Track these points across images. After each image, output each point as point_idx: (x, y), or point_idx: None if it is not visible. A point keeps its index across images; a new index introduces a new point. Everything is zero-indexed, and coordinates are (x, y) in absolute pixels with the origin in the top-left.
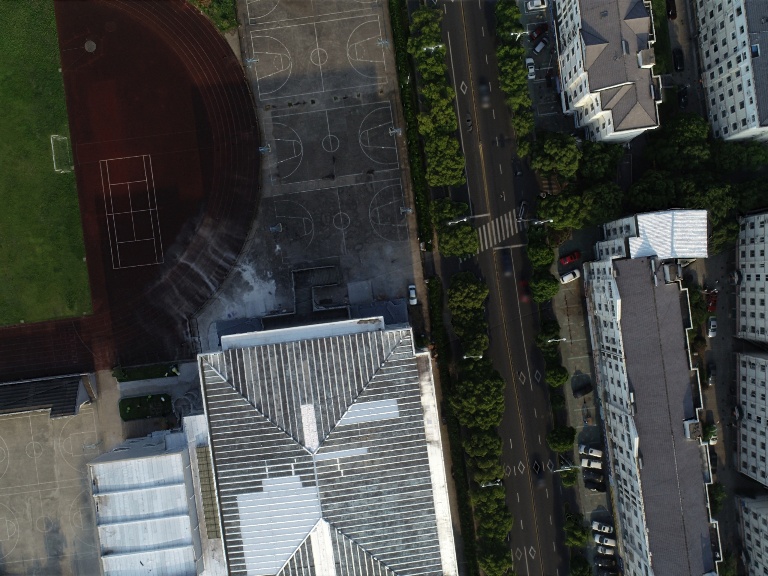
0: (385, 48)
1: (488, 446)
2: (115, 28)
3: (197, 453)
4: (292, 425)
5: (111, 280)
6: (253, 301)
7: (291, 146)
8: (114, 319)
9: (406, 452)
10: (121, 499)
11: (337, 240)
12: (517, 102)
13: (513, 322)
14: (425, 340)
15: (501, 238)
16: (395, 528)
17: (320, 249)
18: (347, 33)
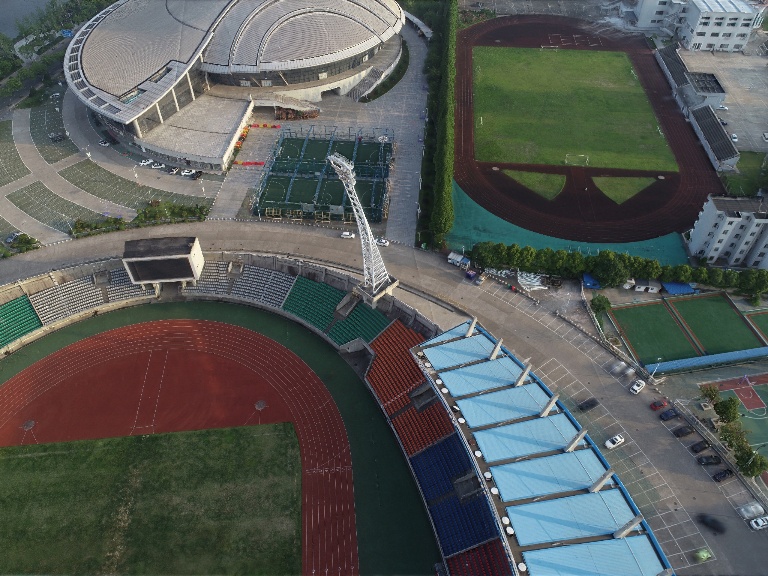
0: None
1: None
2: None
3: None
4: None
5: None
6: (614, 21)
7: (546, 10)
8: None
9: None
10: None
11: None
12: None
13: None
14: None
15: None
16: None
17: None
18: None
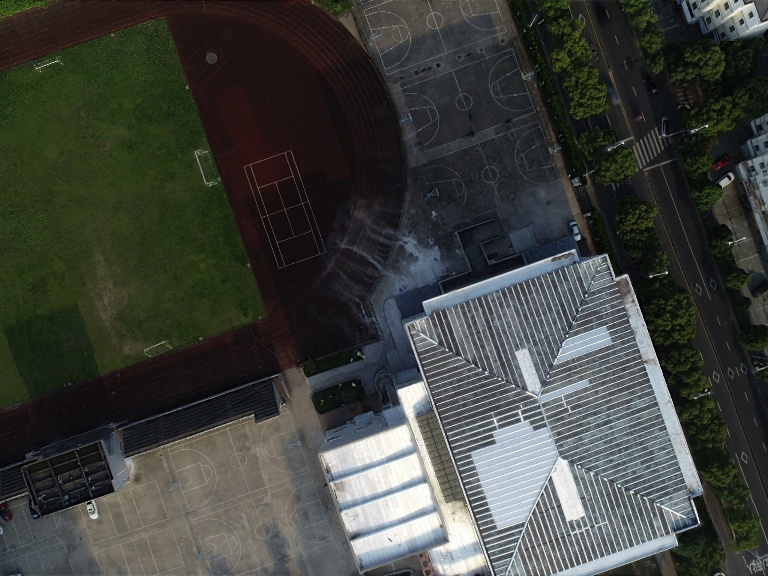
0: None
1: (689, 359)
2: (232, 35)
3: (418, 422)
4: (511, 373)
5: (279, 280)
6: (421, 271)
7: (426, 113)
8: (289, 317)
9: (626, 376)
10: (357, 481)
11: (490, 194)
12: (645, 20)
13: (678, 237)
14: None
15: (649, 158)
16: (631, 452)
17: (475, 206)
18: None
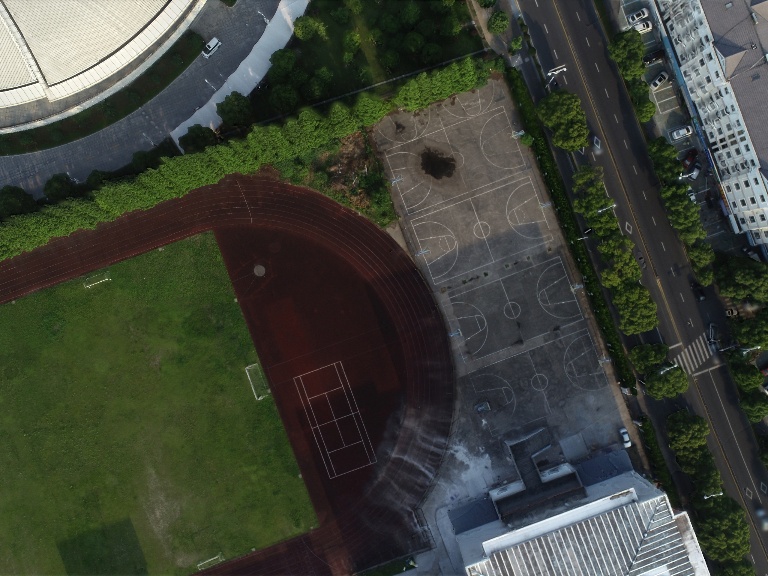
0: (544, 207)
1: (745, 575)
2: (279, 248)
3: None
4: None
5: (330, 490)
6: (472, 479)
7: (474, 321)
8: (341, 527)
9: None
10: None
11: (539, 402)
12: (694, 238)
13: (728, 442)
14: (647, 479)
15: (698, 363)
16: None
17: (525, 414)
18: (504, 201)
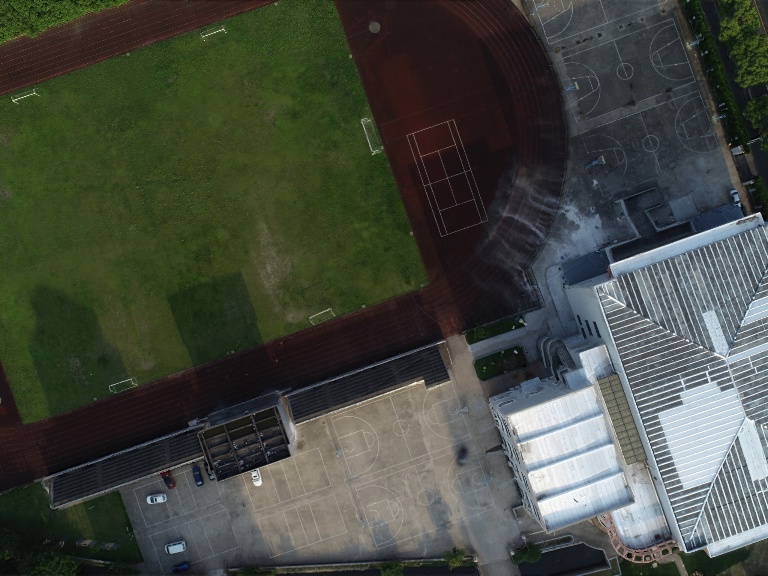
0: None
1: None
2: (395, 5)
3: (601, 385)
4: (698, 334)
5: (441, 248)
6: (582, 239)
7: (587, 82)
8: (451, 285)
9: None
10: (543, 443)
11: (650, 163)
12: None
13: None
14: None
15: None
16: None
17: (636, 175)
18: None
